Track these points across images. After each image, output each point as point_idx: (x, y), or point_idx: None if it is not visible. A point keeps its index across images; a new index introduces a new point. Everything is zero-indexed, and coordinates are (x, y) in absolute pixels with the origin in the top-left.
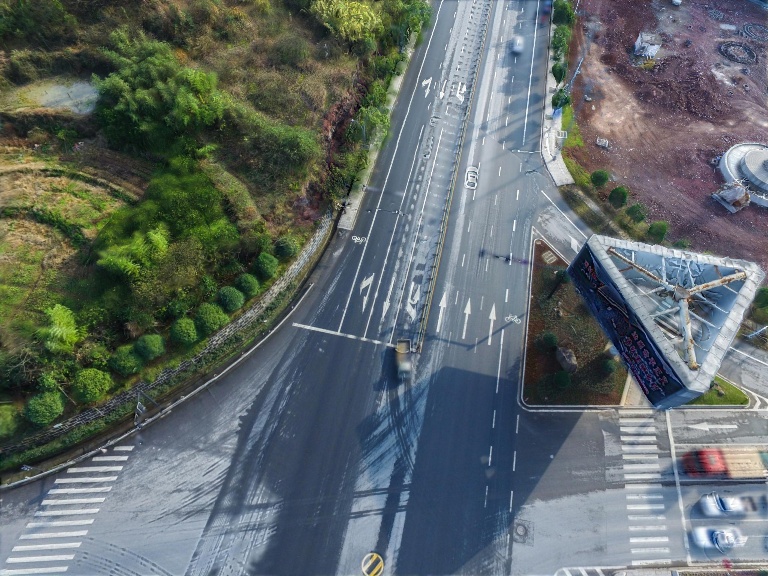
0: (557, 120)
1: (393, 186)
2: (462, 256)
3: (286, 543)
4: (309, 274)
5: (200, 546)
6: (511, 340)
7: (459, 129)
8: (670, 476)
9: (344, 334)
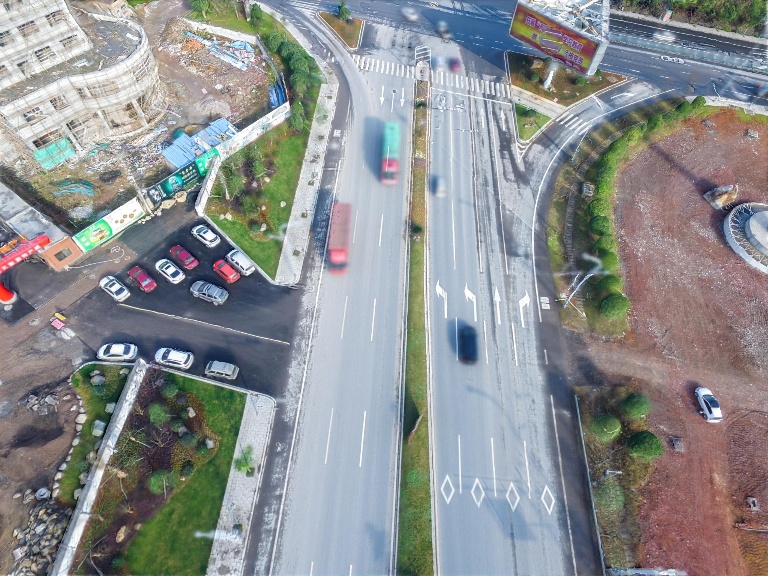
0: (767, 114)
1: None
2: None
3: None
4: None
5: None
6: None
7: None
8: (473, 94)
9: None
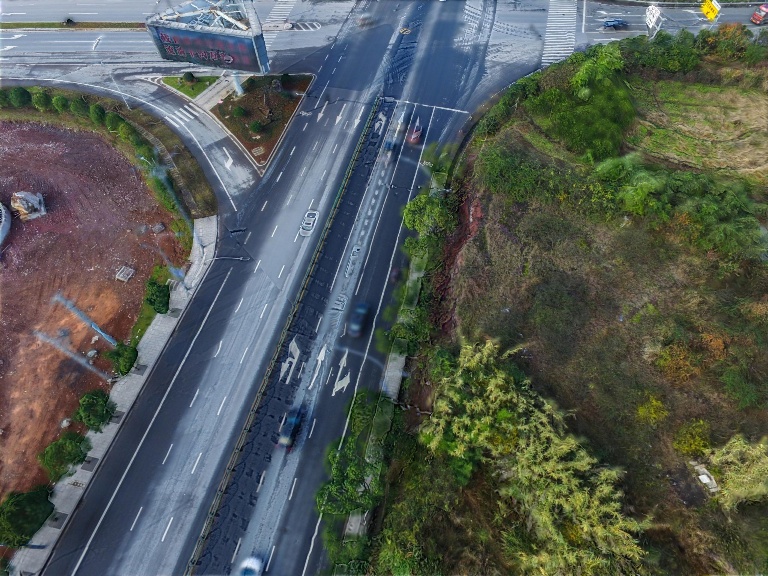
0: None
1: (396, 213)
2: (336, 152)
3: (448, 37)
4: (465, 143)
5: (489, 37)
6: (311, 103)
7: (309, 290)
8: None
9: (431, 107)
